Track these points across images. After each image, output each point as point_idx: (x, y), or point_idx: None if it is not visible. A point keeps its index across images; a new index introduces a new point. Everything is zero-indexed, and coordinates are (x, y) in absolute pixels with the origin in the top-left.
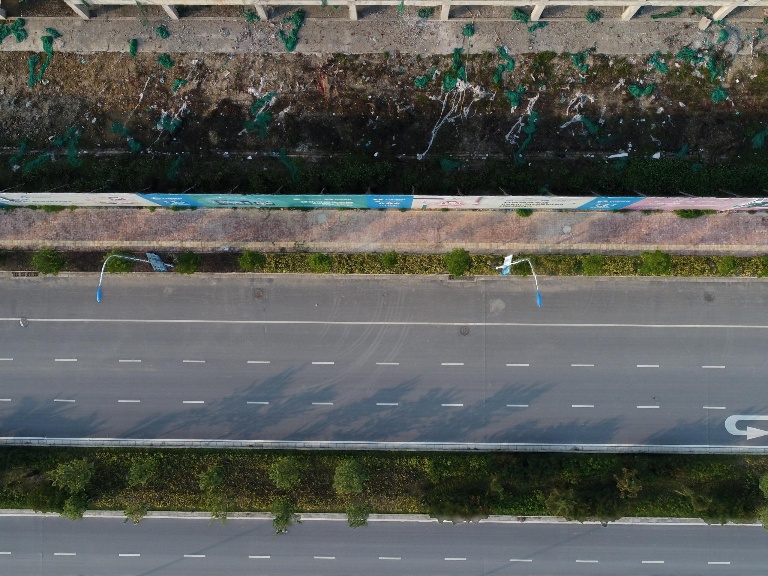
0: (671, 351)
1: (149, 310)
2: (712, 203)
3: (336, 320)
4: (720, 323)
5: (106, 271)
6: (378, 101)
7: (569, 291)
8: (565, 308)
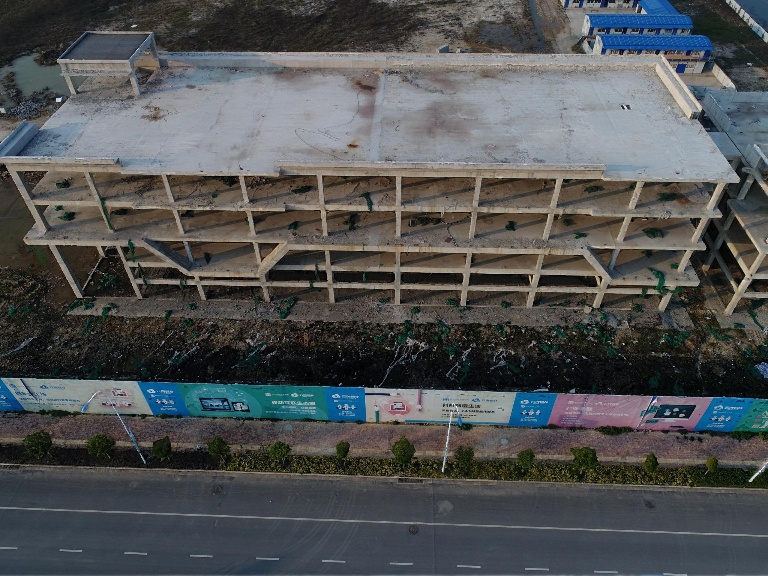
0: (626, 556)
1: (109, 502)
2: (619, 408)
3: (287, 516)
4: (668, 529)
5: (83, 465)
6: (345, 349)
7: (513, 495)
8: (511, 511)
